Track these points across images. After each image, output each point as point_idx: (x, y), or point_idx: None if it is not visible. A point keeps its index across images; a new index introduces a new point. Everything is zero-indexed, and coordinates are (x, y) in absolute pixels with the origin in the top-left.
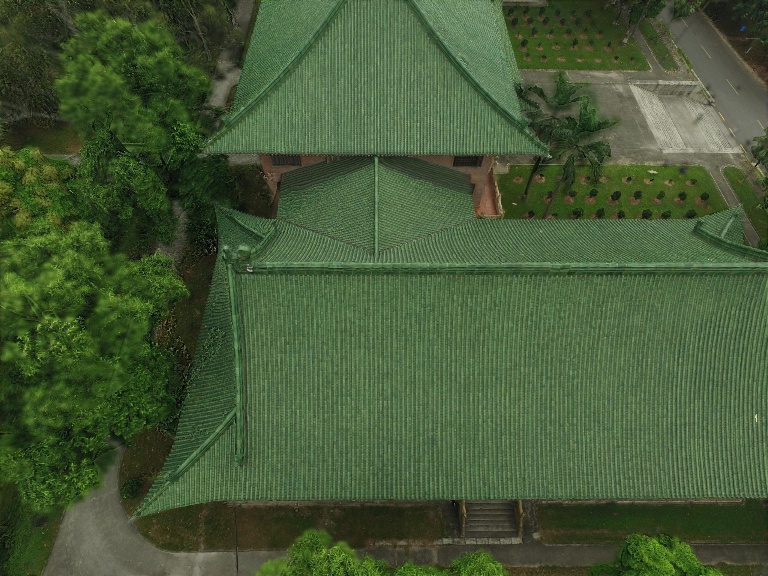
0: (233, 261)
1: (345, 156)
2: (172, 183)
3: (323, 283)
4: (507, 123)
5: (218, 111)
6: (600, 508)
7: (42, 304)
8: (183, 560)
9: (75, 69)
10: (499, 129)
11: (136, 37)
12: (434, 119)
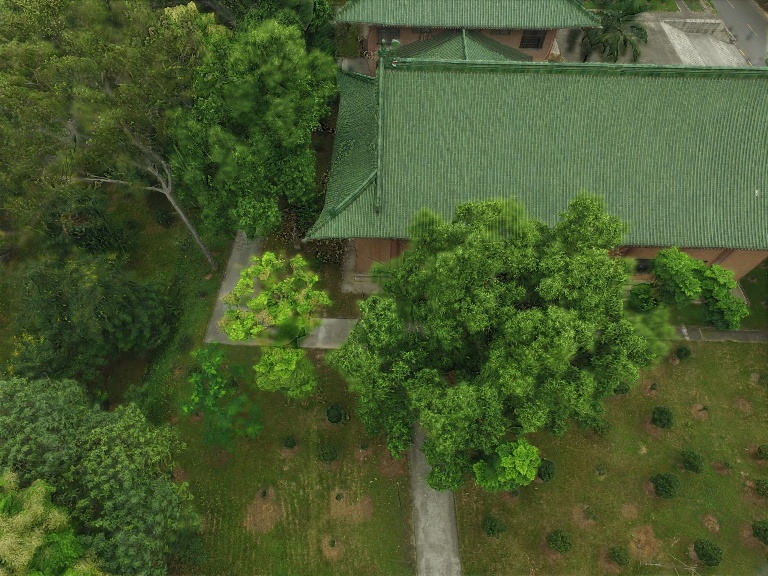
0: (386, 54)
1: (436, 34)
2: (308, 43)
3: (443, 79)
4: (567, 3)
5: None
6: (633, 304)
7: (185, 158)
8: (312, 322)
9: (184, 1)
10: (561, 8)
11: None
12: (510, 1)
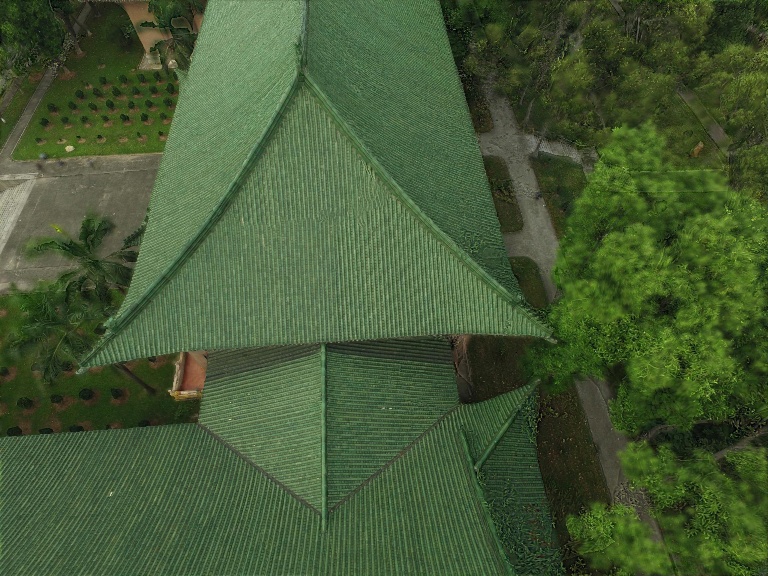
0: None
1: None
2: None
3: None
4: None
5: (521, 190)
6: None
7: None
8: None
9: None
10: None
11: (688, 247)
12: None
